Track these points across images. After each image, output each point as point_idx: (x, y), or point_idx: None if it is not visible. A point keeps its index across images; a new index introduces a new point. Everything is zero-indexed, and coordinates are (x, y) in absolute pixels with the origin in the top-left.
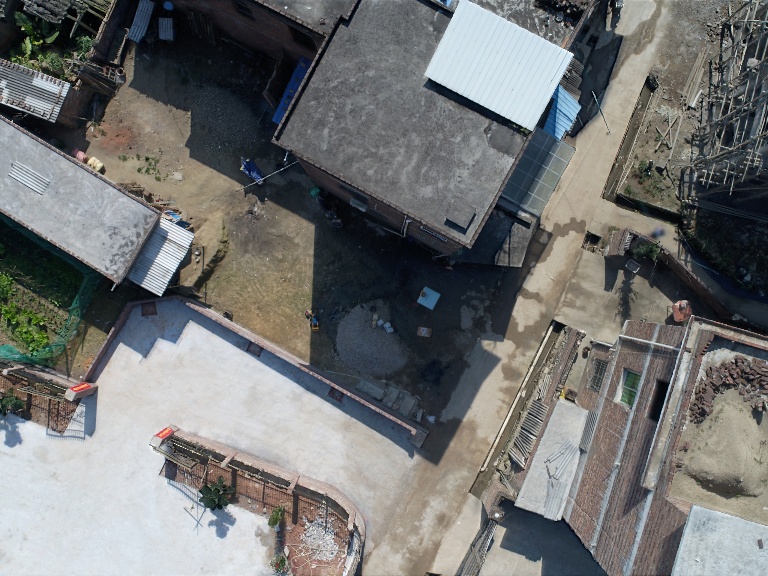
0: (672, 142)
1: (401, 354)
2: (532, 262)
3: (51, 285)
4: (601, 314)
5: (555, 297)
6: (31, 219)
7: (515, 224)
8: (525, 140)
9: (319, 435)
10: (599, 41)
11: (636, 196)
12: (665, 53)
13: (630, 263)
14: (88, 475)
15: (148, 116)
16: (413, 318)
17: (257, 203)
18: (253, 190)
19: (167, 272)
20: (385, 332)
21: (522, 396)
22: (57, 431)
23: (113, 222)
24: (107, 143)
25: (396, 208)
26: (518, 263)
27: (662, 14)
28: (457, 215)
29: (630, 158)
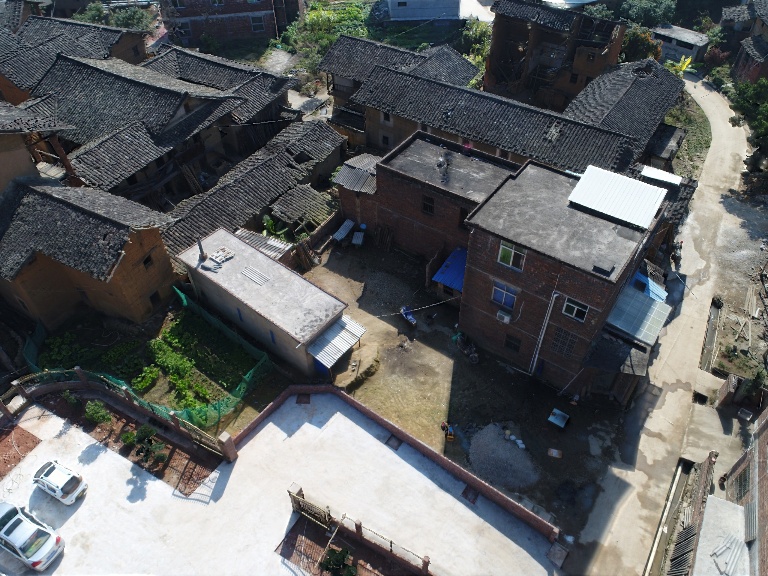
0: (748, 336)
1: (533, 470)
2: (649, 408)
3: (226, 370)
4: (727, 454)
5: (677, 438)
6: (248, 298)
7: (633, 349)
8: (643, 234)
9: (450, 535)
10: (669, 276)
11: (730, 370)
12: (722, 286)
13: (742, 413)
14: (199, 542)
15: (332, 283)
16: (543, 440)
17: (407, 341)
18: (405, 332)
19: (339, 352)
20: (517, 447)
21: (664, 532)
22: (183, 494)
23: (310, 306)
24: None
25: (555, 257)
26: (642, 373)
27: (712, 267)
28: (602, 264)
29: (715, 346)
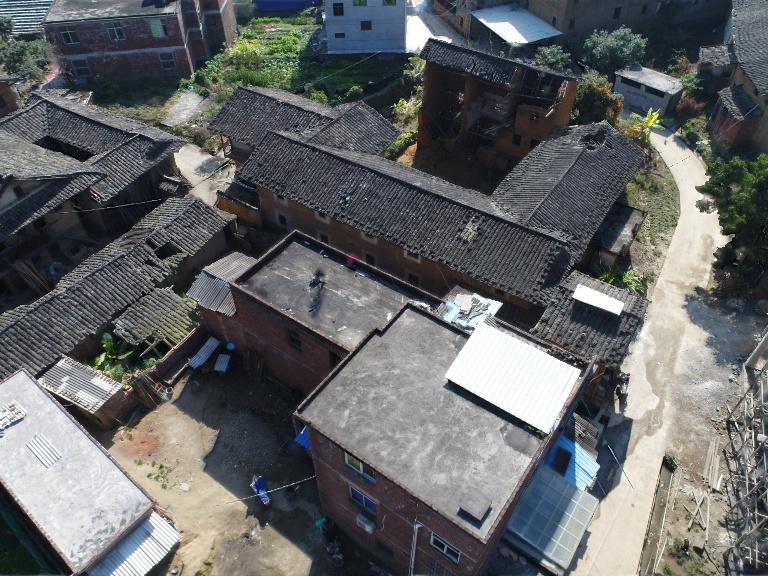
0: (705, 522)
1: None
2: None
3: None
4: None
5: None
6: (23, 490)
7: (539, 574)
8: (541, 442)
9: None
10: (610, 421)
11: None
12: (677, 438)
13: None
14: None
15: (178, 430)
16: None
17: (256, 527)
18: (256, 512)
19: (134, 575)
20: None
21: None
22: None
23: (103, 505)
24: (130, 446)
25: (406, 489)
26: None
27: (666, 406)
28: (471, 505)
29: (662, 535)
